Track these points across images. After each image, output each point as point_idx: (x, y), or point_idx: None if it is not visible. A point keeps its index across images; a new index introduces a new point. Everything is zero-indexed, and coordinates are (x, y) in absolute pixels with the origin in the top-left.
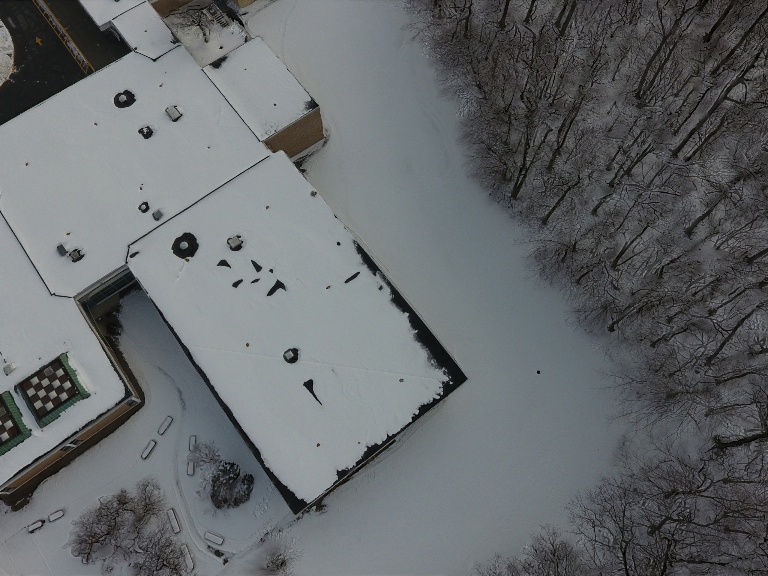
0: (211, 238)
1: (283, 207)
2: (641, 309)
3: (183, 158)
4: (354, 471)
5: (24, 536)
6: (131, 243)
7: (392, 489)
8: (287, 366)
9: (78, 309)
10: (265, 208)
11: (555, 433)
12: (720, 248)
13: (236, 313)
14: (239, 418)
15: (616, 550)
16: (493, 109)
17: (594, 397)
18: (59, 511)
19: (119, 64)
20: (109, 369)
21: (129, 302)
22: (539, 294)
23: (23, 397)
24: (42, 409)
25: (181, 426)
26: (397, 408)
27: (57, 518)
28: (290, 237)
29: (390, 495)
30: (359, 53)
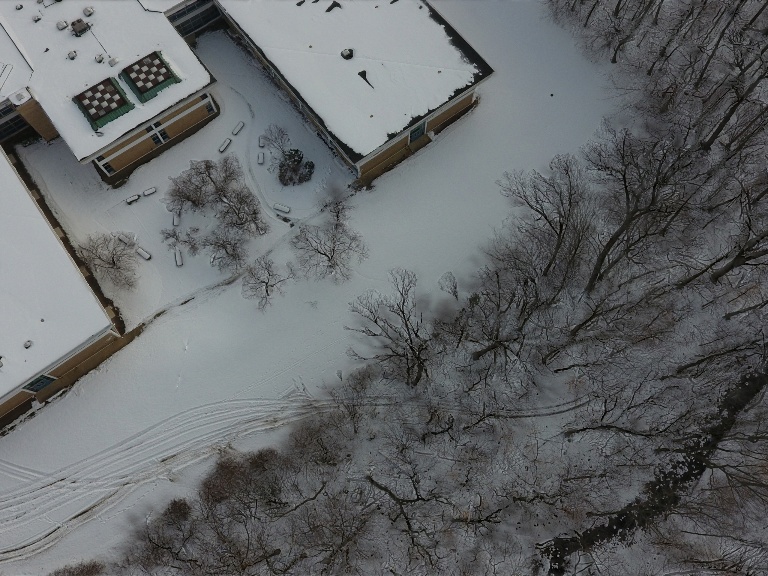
0: None
1: None
2: (639, 45)
3: None
4: (398, 162)
5: (123, 206)
6: None
7: (430, 175)
8: (344, 61)
9: (168, 21)
10: None
11: (566, 138)
12: (707, 2)
13: (300, 24)
14: (306, 97)
15: (618, 175)
16: None
17: (599, 106)
18: (152, 188)
19: None
20: (196, 63)
21: (204, 40)
22: (552, 34)
23: (126, 81)
24: (143, 87)
25: (251, 130)
26: (436, 91)
27: (151, 193)
28: None
29: (428, 179)
30: None
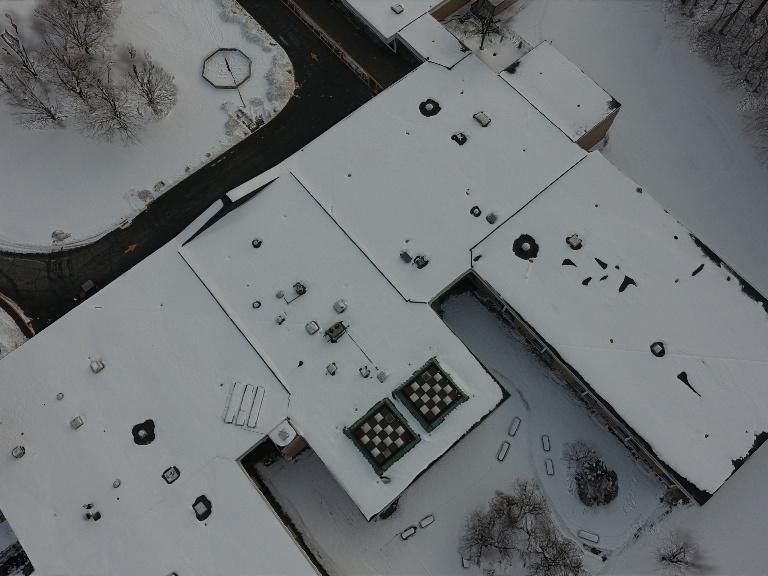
0: (549, 238)
1: (612, 205)
2: None
3: (502, 162)
4: None
5: (398, 543)
6: (472, 247)
7: (754, 479)
8: (656, 360)
9: (435, 314)
10: (594, 207)
11: None
12: None
13: (593, 310)
14: (622, 413)
15: None
16: (767, 101)
17: None
18: (429, 517)
19: (416, 74)
20: (481, 371)
21: (450, 307)
22: None
23: (404, 403)
24: (429, 414)
25: (529, 427)
26: None
27: (428, 524)
28: (627, 234)
29: (753, 485)
30: (618, 54)
